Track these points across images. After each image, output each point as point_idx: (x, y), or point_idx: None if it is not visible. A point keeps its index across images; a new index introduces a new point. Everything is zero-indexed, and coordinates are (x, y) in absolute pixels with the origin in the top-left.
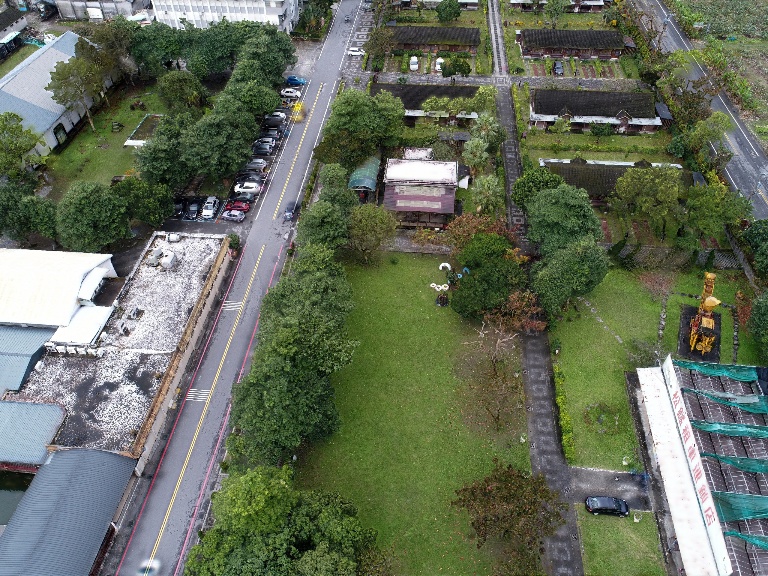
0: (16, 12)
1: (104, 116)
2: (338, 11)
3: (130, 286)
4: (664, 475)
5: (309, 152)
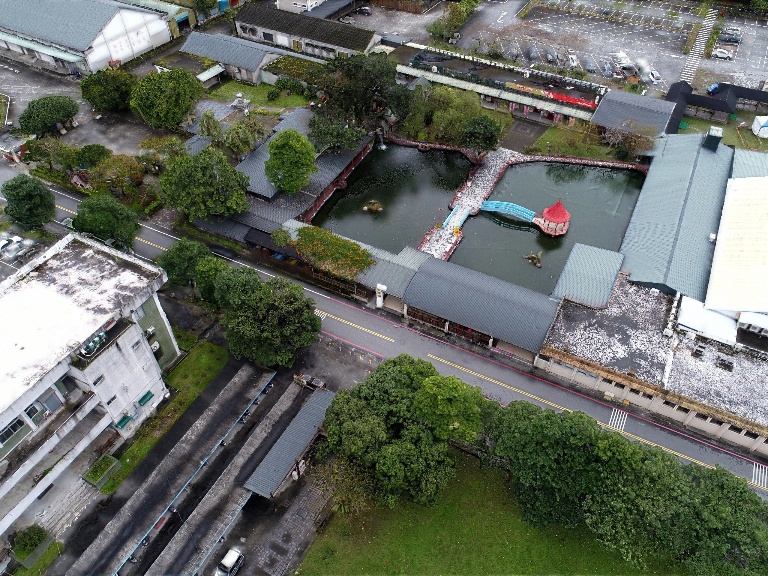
0: None
1: None
2: None
3: None
4: None
5: None
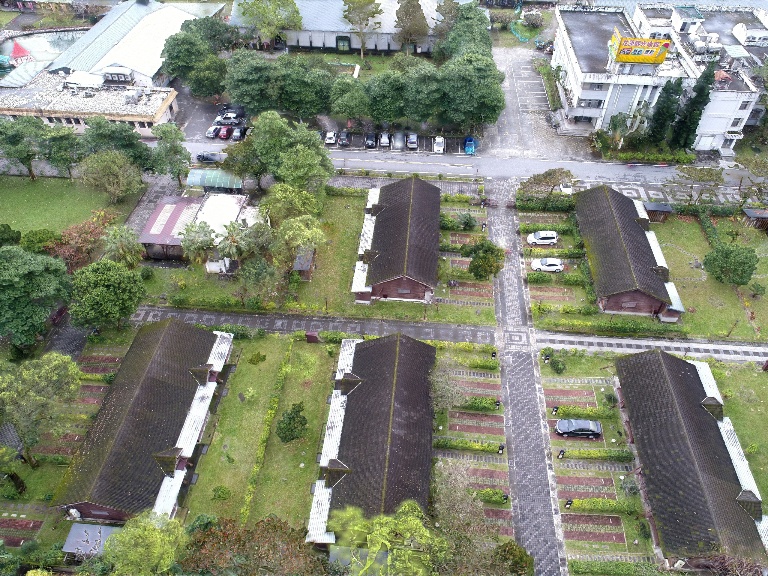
0: None
1: (390, 60)
2: (712, 168)
3: (121, 90)
4: None
5: None
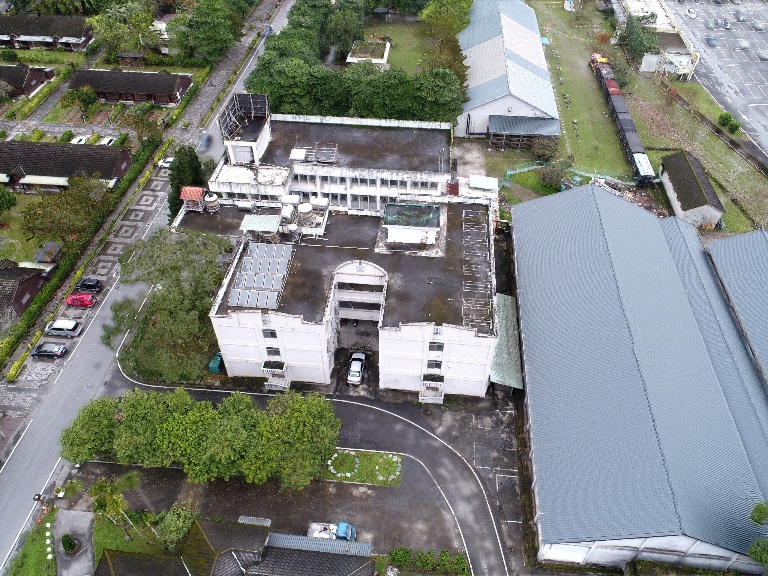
0: (693, 202)
1: None
2: None
3: None
4: None
5: (251, 65)
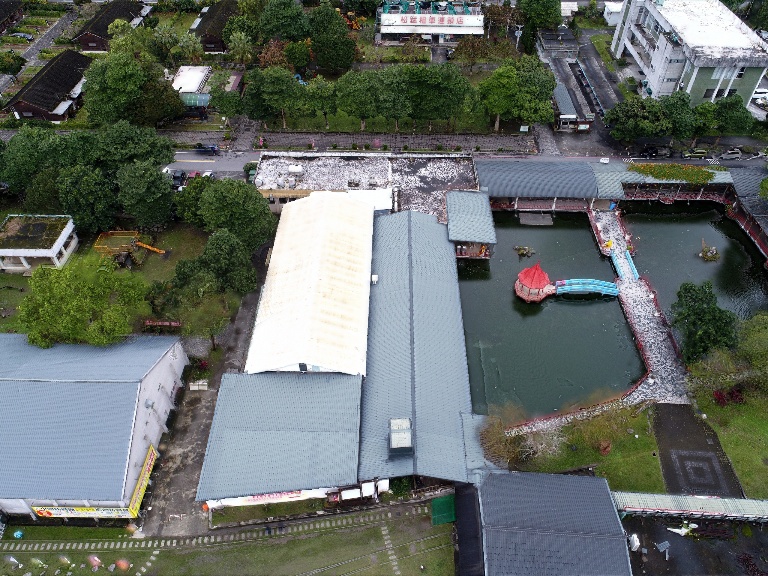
0: None
1: None
2: None
3: None
4: (439, 33)
5: None
